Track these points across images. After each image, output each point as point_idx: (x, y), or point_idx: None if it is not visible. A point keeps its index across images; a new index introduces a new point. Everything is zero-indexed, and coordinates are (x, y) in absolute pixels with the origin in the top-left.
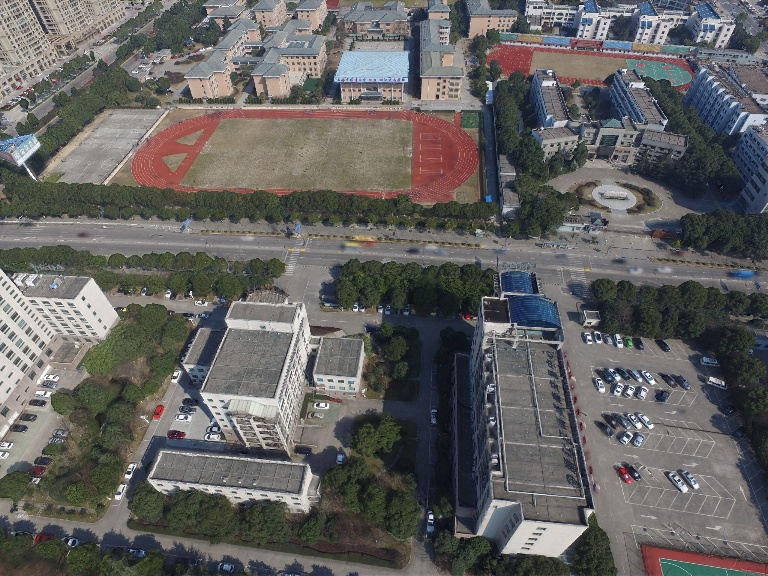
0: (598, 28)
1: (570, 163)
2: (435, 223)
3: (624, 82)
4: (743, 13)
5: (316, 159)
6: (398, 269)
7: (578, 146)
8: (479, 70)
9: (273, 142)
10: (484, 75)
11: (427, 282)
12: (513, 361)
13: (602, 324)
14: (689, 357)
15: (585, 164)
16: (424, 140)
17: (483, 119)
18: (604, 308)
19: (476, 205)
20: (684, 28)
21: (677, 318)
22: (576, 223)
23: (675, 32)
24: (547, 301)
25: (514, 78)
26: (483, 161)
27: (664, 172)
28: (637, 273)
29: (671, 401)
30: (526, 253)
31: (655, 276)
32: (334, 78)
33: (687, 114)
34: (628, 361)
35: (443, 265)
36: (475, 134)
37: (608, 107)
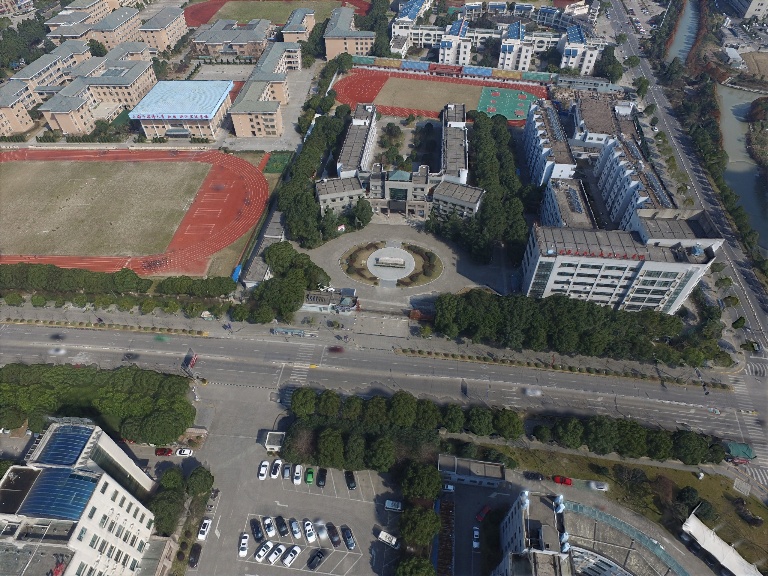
0: (459, 52)
1: (354, 221)
2: (152, 306)
3: (445, 120)
4: (621, 34)
5: (76, 214)
6: (59, 377)
7: (358, 202)
8: (309, 102)
9: (39, 192)
10: (315, 107)
11: (77, 399)
12: (1, 573)
13: (281, 452)
14: (376, 497)
15: (378, 220)
16: (213, 189)
17: (292, 161)
18: (289, 430)
19: (206, 282)
20: (554, 51)
21: (360, 449)
22: (321, 303)
23: (545, 55)
24: (82, 476)
25: (338, 113)
26: (262, 217)
27: (451, 233)
28: (370, 370)
29: (323, 568)
30: (253, 343)
31: (389, 374)
32: (128, 114)
33: (502, 159)
34: (298, 505)
35: (116, 371)
36: (274, 181)
37: (433, 147)
